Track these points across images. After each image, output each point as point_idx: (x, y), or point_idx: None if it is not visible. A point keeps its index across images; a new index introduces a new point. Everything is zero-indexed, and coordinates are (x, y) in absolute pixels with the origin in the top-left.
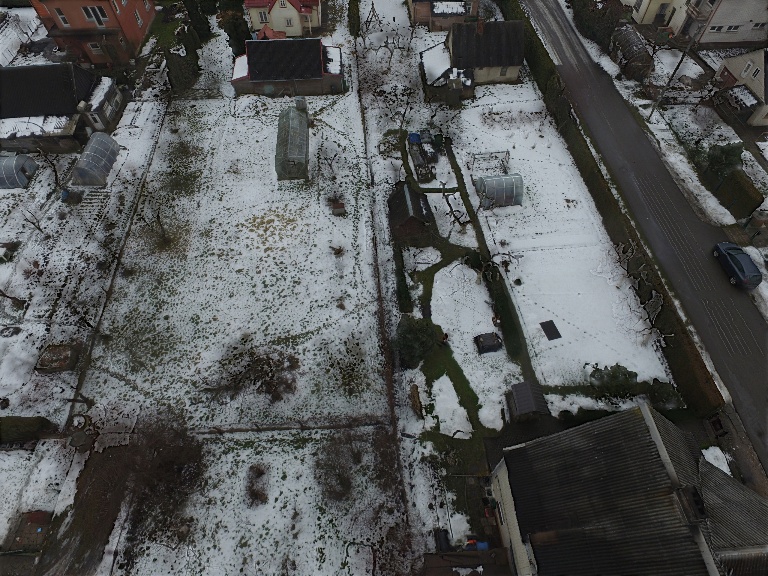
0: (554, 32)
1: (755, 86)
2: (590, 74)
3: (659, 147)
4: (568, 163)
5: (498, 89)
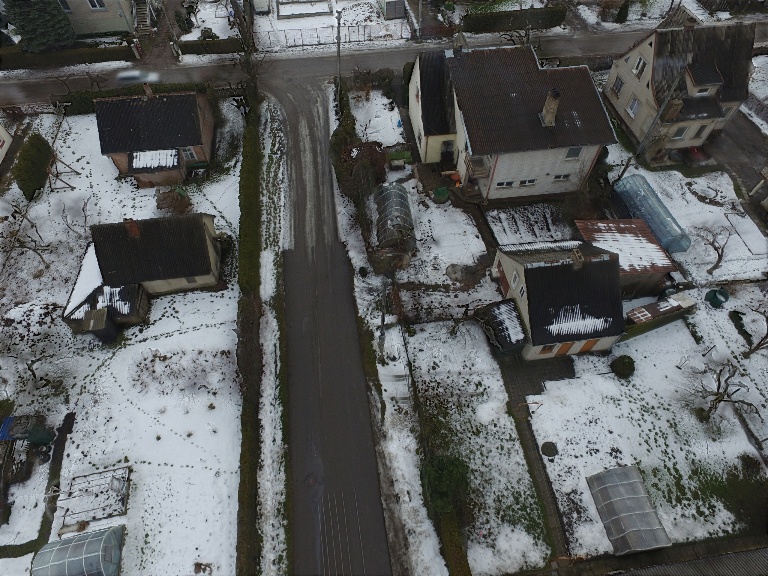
0: (304, 184)
1: (523, 310)
2: (326, 266)
3: (381, 419)
4: (232, 467)
5: (187, 303)
